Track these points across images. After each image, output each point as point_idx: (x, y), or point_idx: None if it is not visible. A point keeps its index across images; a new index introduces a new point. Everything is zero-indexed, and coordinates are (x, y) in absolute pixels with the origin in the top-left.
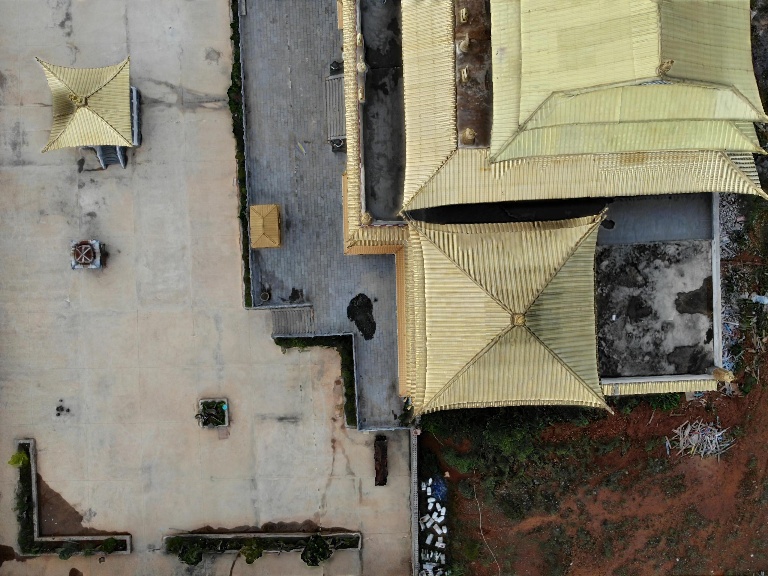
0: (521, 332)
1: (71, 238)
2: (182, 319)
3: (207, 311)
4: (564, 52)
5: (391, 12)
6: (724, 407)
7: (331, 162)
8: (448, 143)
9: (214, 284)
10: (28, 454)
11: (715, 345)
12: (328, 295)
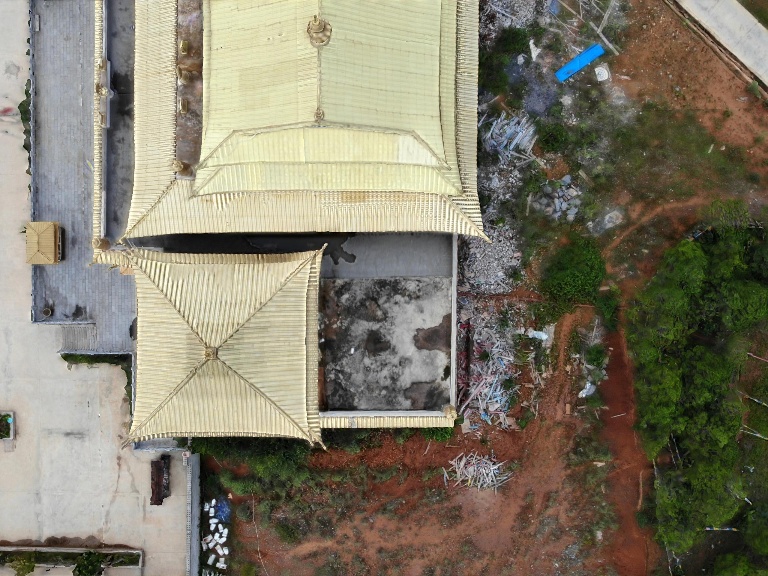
0: (217, 365)
1: None
2: None
3: None
4: (244, 91)
5: None
6: (499, 441)
7: None
8: (169, 173)
9: (5, 297)
10: None
11: (451, 382)
12: (111, 313)
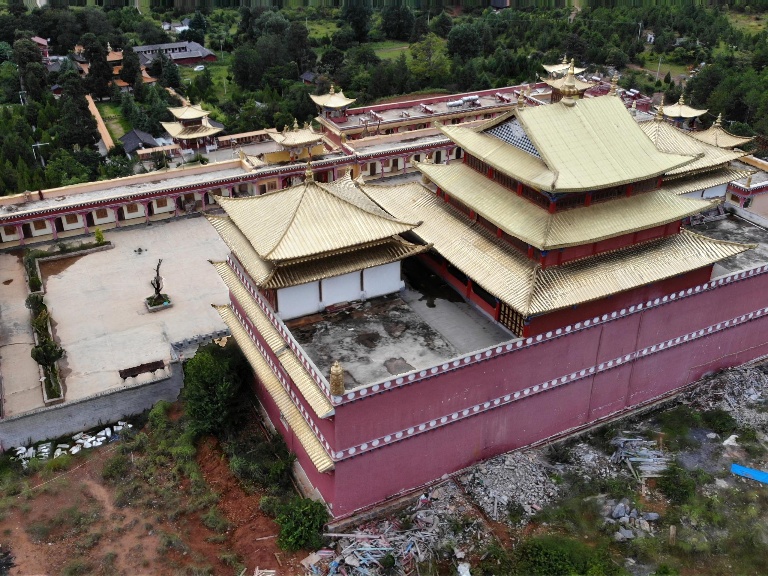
0: None
1: None
2: None
3: None
4: None
5: None
6: None
7: None
8: None
9: None
10: (103, 245)
11: None
12: None
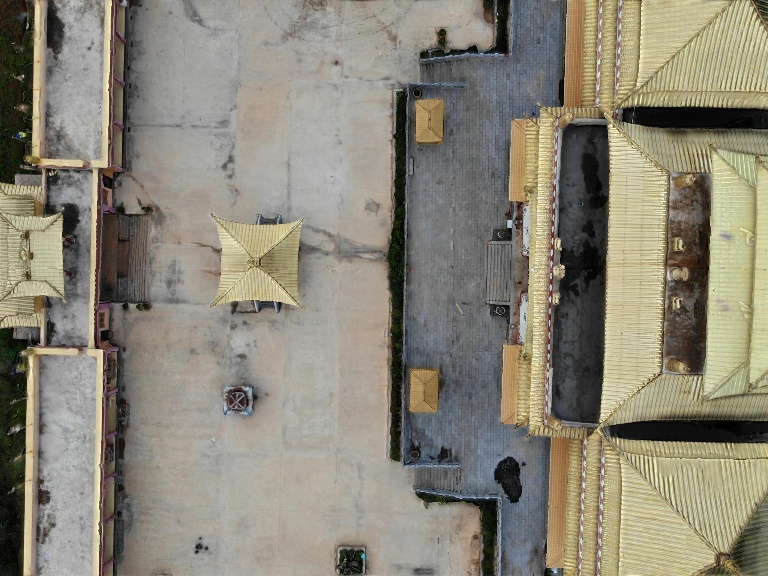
0: (723, 569)
1: (220, 378)
2: (325, 465)
3: (351, 459)
4: None
5: (587, 214)
6: None
7: (488, 325)
8: (651, 366)
9: (359, 433)
10: None
11: None
12: (477, 456)
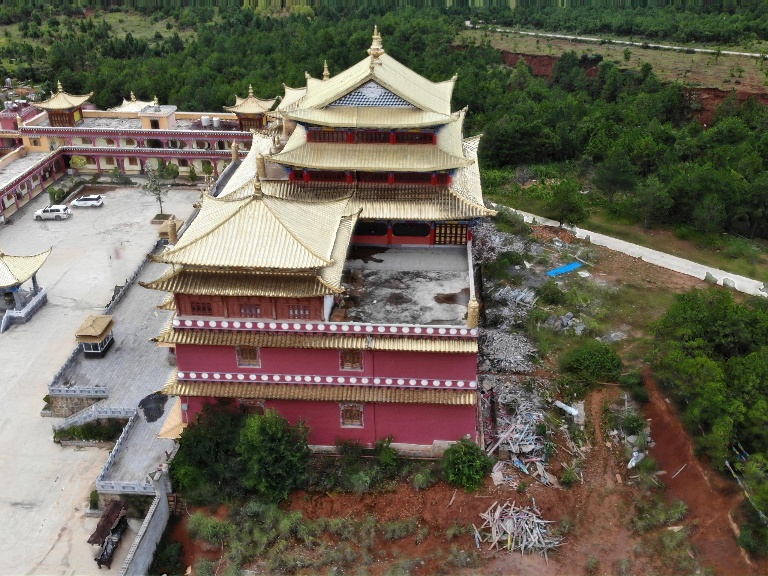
0: (259, 206)
1: None
2: None
3: (2, 415)
4: None
5: None
6: (541, 492)
7: None
8: None
9: (24, 399)
10: None
11: None
12: (128, 391)
